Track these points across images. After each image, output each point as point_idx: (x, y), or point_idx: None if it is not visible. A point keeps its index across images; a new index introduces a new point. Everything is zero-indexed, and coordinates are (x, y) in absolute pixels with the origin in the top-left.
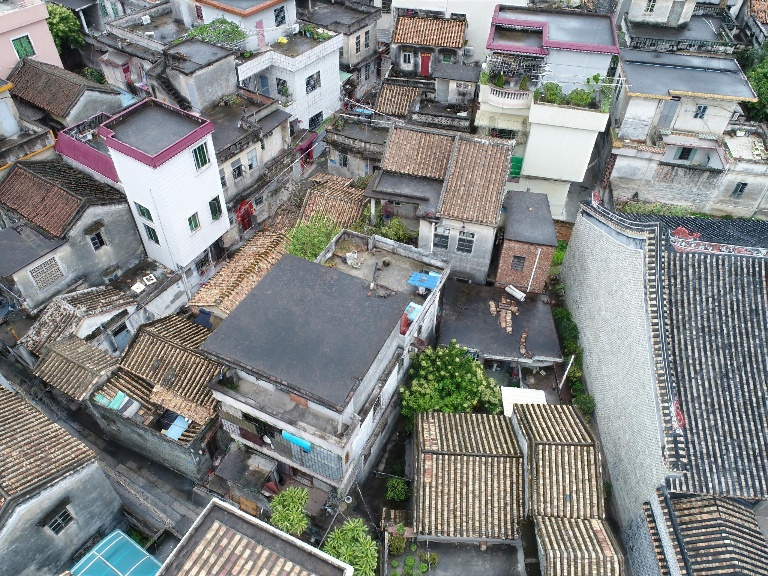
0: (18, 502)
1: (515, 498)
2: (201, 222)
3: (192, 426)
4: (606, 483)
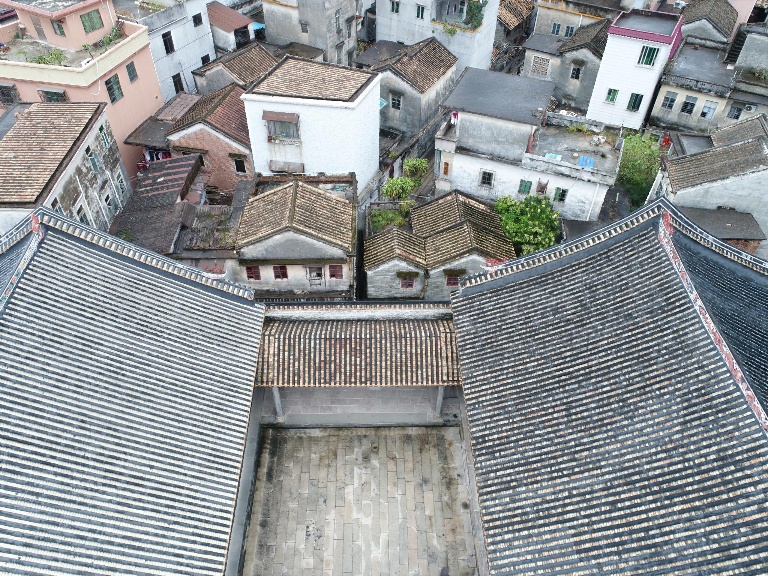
0: (390, 68)
1: None
2: (618, 101)
3: None
4: None
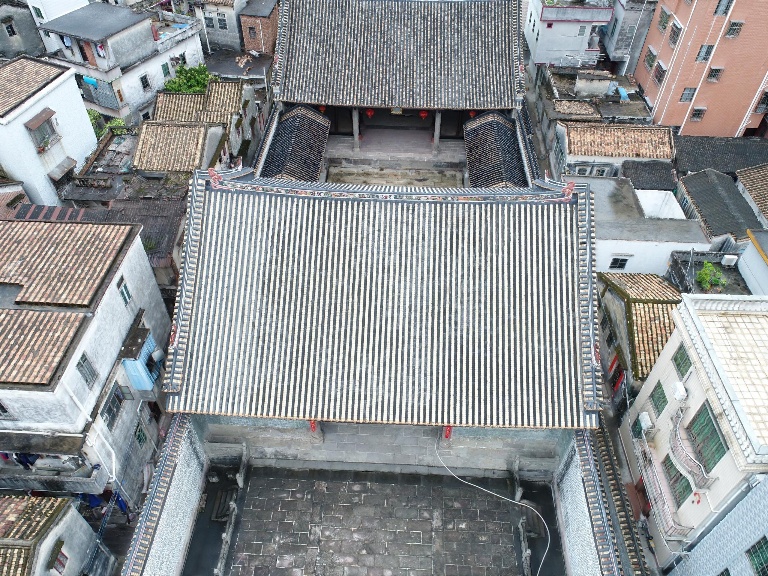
0: None
1: None
2: None
3: None
4: None
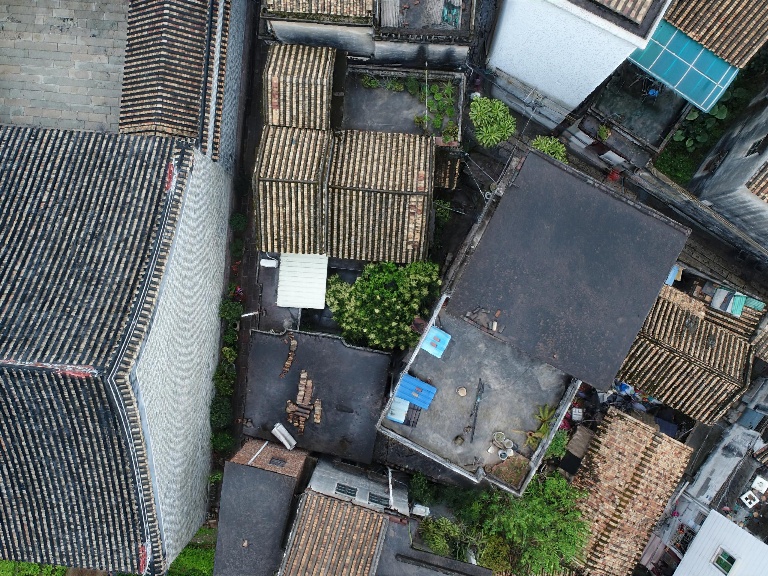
0: None
1: (340, 158)
2: (713, 570)
3: None
4: (233, 227)
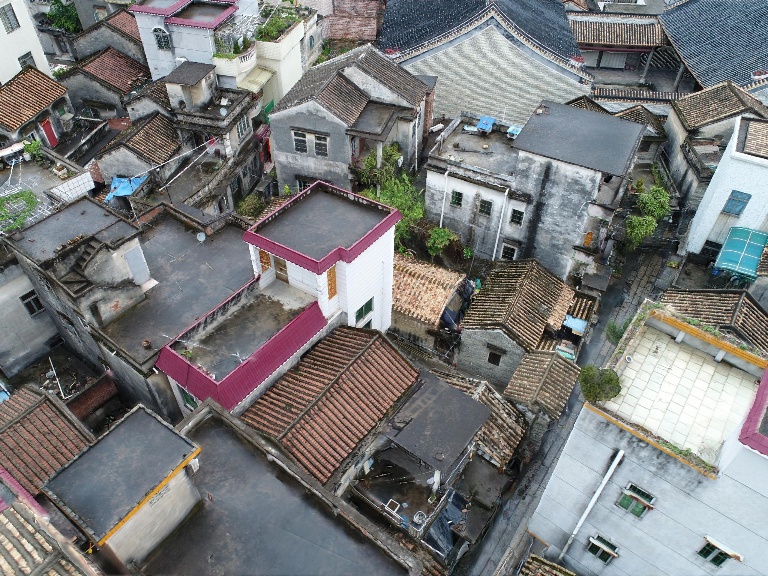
0: None
1: None
2: None
3: (569, 308)
4: None
